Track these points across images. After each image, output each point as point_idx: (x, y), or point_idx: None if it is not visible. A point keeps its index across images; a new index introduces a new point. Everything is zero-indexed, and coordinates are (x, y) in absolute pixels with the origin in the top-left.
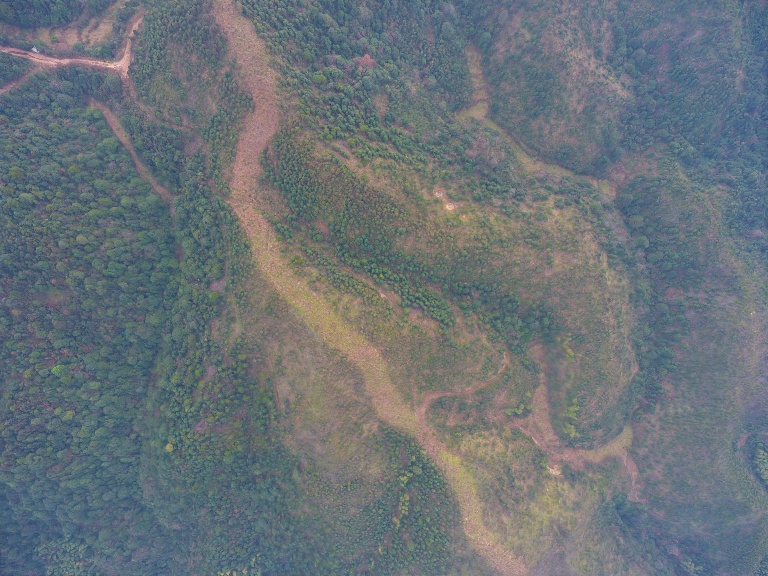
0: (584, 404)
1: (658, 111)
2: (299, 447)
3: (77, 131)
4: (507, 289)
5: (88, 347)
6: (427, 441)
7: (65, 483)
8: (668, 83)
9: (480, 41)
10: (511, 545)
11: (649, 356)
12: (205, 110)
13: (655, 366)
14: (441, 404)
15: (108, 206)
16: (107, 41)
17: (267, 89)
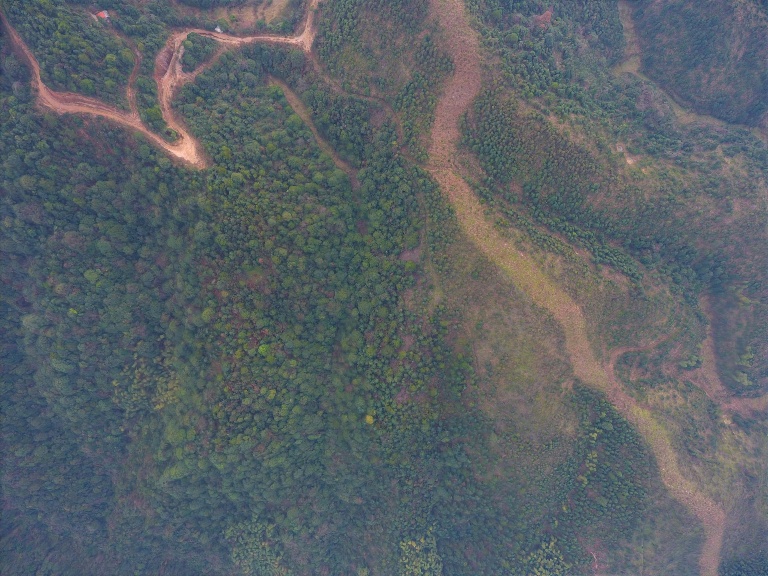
0: (758, 351)
1: None
2: (500, 410)
3: (266, 109)
4: (686, 240)
5: (282, 326)
6: (617, 396)
7: (267, 462)
8: None
9: None
10: (709, 492)
11: None
12: (397, 78)
13: None
14: (624, 360)
15: (303, 182)
16: None
17: (470, 50)
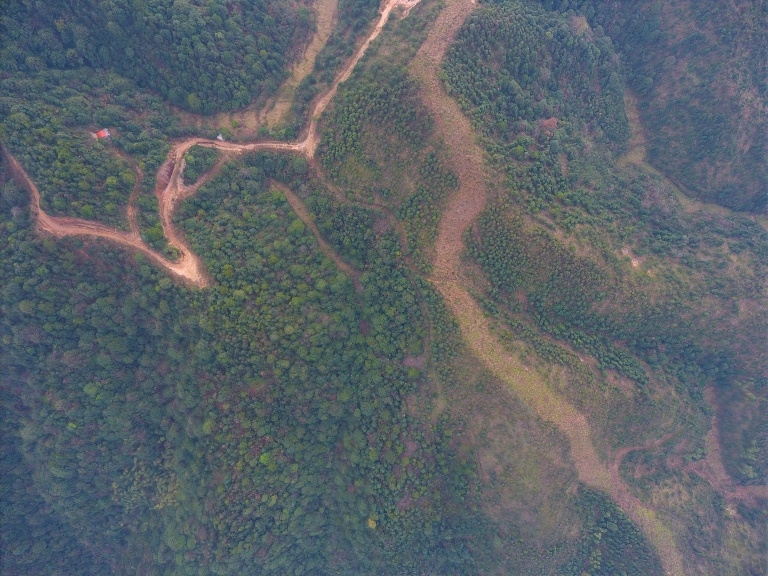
0: (763, 445)
1: None
2: (504, 516)
3: (268, 217)
4: (691, 339)
5: (284, 430)
6: (622, 497)
7: (268, 565)
8: None
9: (640, 86)
10: None
11: None
12: (401, 189)
13: None
14: (629, 458)
15: (306, 291)
16: (285, 121)
17: (475, 168)
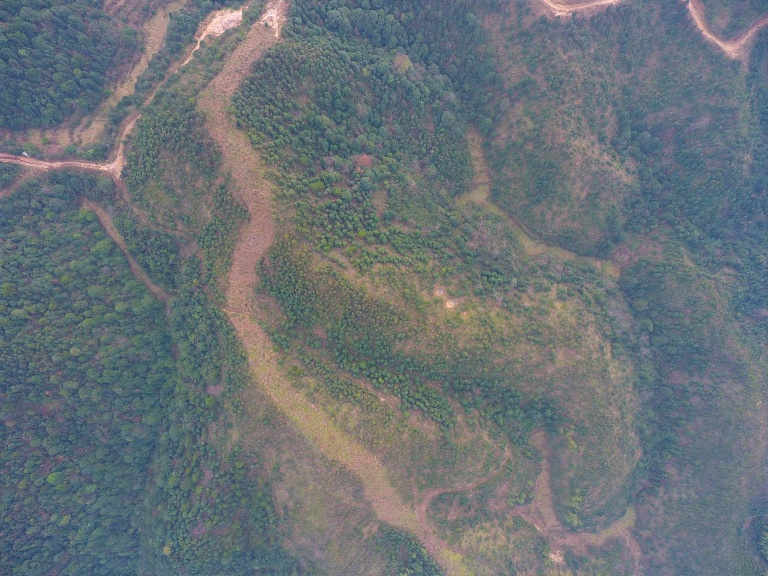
0: (587, 494)
1: (663, 194)
2: (298, 551)
3: (70, 236)
4: (509, 384)
5: (84, 449)
6: (428, 539)
7: None
8: (674, 165)
9: (481, 126)
10: None
11: (653, 439)
12: (200, 217)
13: (659, 449)
14: (442, 499)
15: (102, 313)
16: (99, 141)
17: (263, 202)
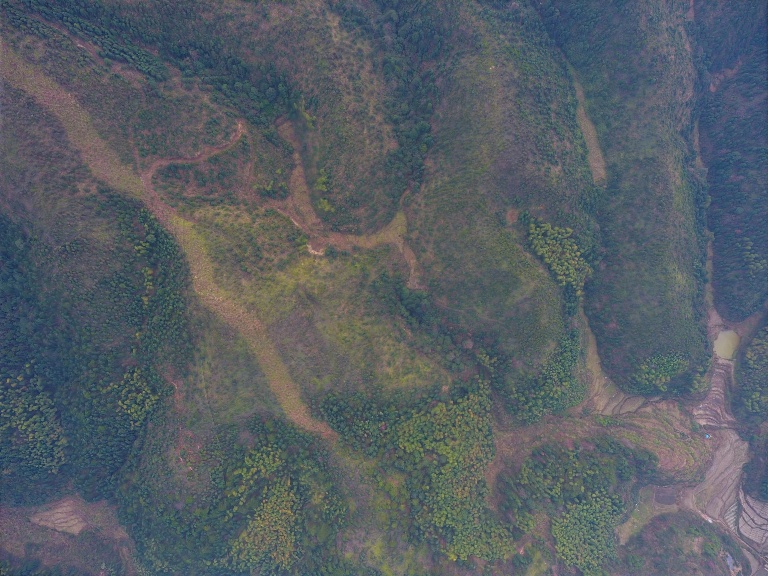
0: (332, 174)
1: None
2: (12, 209)
3: None
4: (228, 49)
5: None
6: (155, 205)
7: None
8: None
9: None
10: (243, 301)
11: (410, 134)
12: None
13: (418, 146)
14: (174, 173)
15: None
16: None
17: None
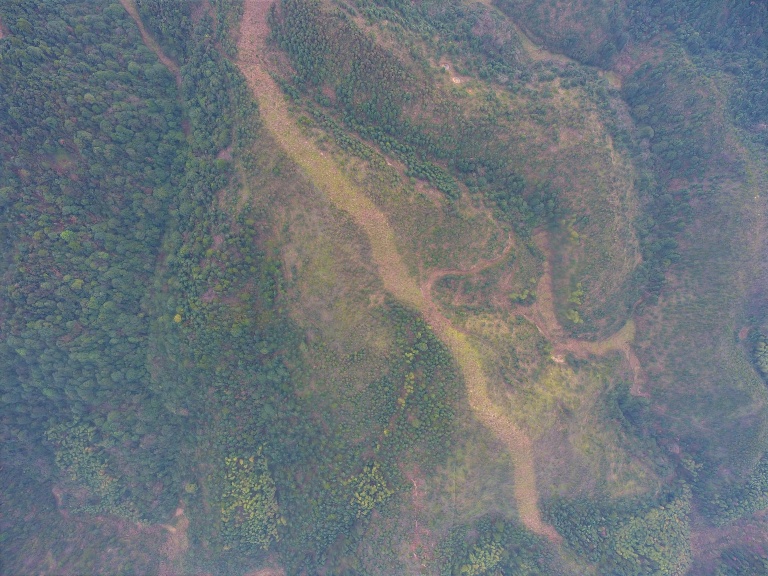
0: (588, 289)
1: None
2: (306, 316)
3: None
4: (513, 167)
5: (96, 218)
6: (433, 316)
7: (74, 355)
8: None
9: None
10: (515, 417)
11: (653, 248)
12: None
13: (658, 258)
14: (446, 283)
15: (115, 69)
16: None
17: None
